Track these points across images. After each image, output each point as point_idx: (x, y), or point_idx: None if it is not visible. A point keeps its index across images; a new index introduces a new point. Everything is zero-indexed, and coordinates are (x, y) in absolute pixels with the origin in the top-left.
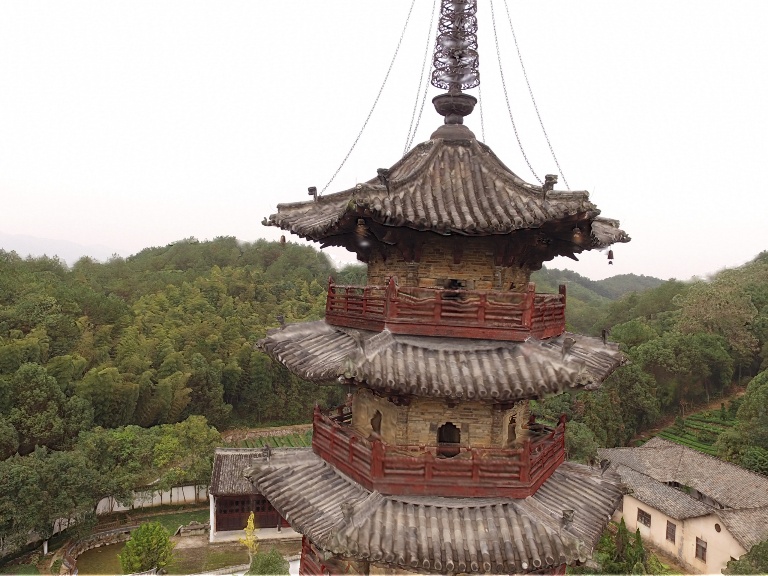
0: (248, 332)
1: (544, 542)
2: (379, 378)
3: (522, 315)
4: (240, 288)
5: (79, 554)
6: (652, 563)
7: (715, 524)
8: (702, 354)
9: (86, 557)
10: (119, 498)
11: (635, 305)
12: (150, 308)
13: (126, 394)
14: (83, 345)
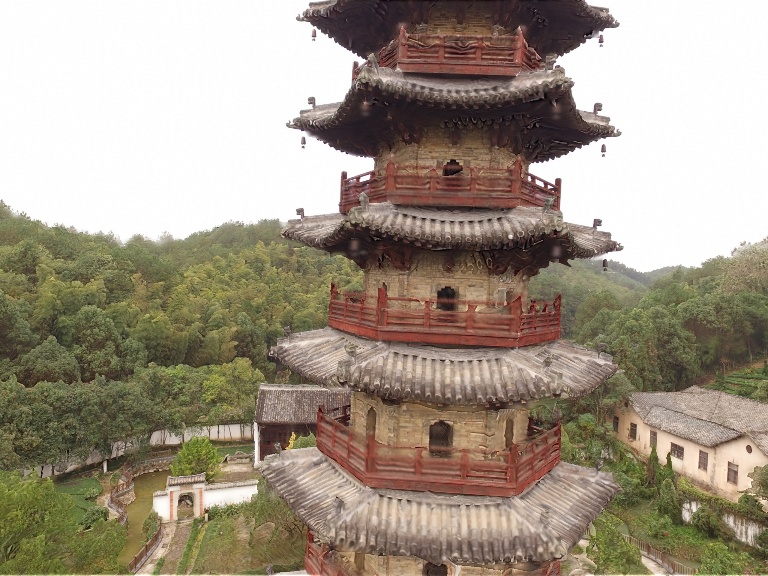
0: (291, 298)
1: (529, 226)
2: (389, 84)
3: (514, 54)
4: (283, 260)
5: (135, 476)
6: (682, 482)
7: (746, 446)
8: (744, 312)
9: (141, 479)
10: (171, 428)
11: (679, 281)
12: (198, 276)
13: (177, 341)
14: (137, 297)
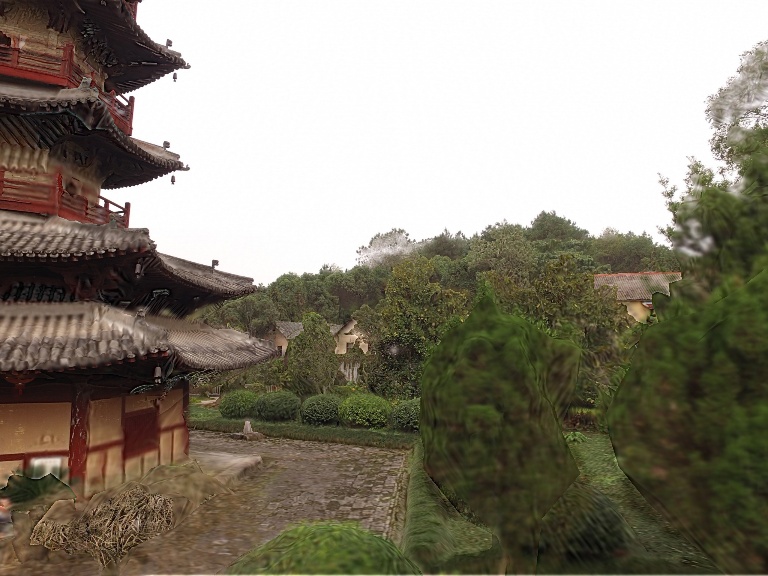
0: None
1: None
2: None
3: None
4: None
5: None
6: None
7: None
8: (376, 281)
9: None
10: None
11: None
12: None
13: None
14: None
